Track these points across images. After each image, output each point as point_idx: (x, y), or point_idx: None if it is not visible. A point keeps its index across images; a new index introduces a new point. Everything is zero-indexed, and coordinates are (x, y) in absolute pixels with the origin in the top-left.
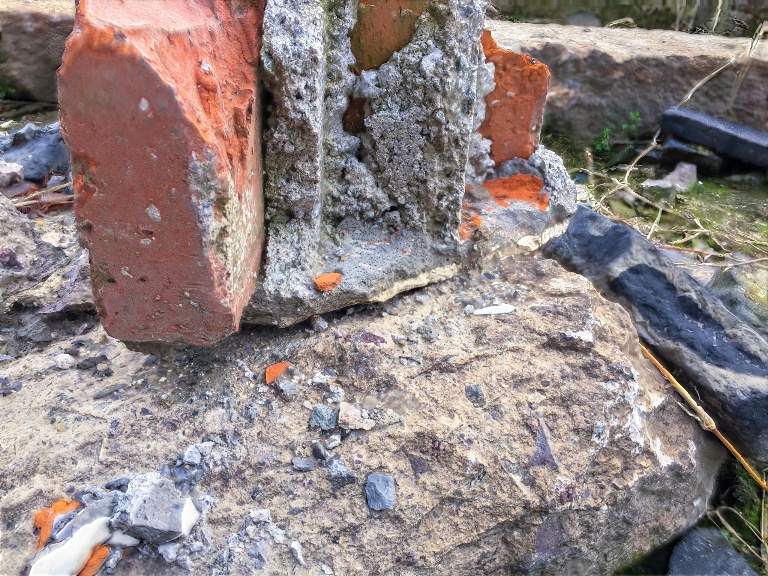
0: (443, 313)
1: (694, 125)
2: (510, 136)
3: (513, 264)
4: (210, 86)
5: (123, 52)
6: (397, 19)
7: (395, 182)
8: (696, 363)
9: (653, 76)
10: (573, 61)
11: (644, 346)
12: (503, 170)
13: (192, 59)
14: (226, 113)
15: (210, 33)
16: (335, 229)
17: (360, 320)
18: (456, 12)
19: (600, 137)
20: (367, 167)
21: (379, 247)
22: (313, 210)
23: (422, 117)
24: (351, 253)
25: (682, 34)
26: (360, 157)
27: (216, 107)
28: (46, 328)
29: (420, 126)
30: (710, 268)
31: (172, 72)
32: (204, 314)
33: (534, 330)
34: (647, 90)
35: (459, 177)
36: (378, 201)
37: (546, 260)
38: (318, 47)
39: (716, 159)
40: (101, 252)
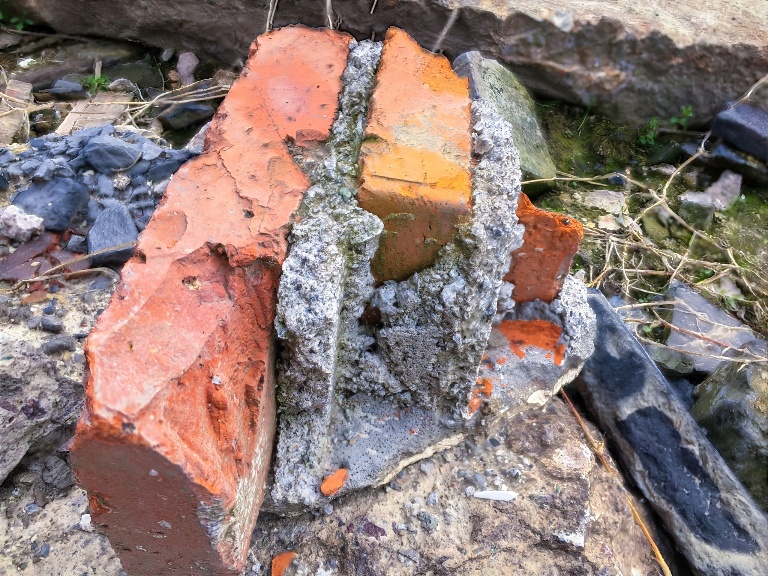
0: (445, 490)
1: (748, 133)
2: (534, 282)
3: (520, 425)
4: (220, 405)
5: (132, 444)
6: (420, 245)
7: (408, 376)
8: (685, 534)
9: (714, 65)
10: (629, 41)
11: (639, 496)
12: (523, 313)
13: (203, 381)
14: (237, 402)
15: (222, 327)
16: (346, 400)
17: (364, 496)
18: (483, 242)
19: (646, 127)
20: (381, 358)
21: (388, 424)
22: (324, 406)
23: (438, 335)
24: (360, 432)
25: (757, 1)
26: (375, 347)
27: (226, 421)
28: (70, 472)
29: (436, 340)
30: (732, 321)
31: (182, 423)
32: (213, 573)
33: (529, 526)
34: (705, 79)
35: (473, 370)
36: (390, 386)
37: (553, 425)
38: (333, 314)
39: (764, 172)
40: (116, 538)
